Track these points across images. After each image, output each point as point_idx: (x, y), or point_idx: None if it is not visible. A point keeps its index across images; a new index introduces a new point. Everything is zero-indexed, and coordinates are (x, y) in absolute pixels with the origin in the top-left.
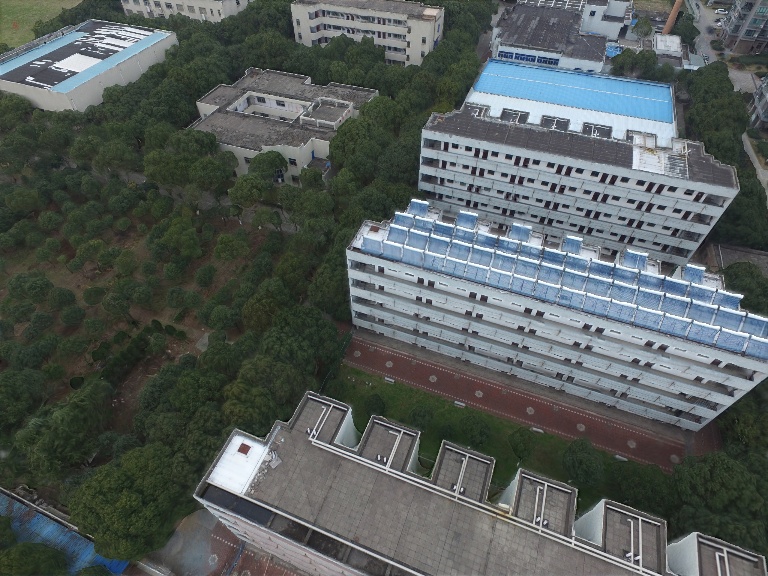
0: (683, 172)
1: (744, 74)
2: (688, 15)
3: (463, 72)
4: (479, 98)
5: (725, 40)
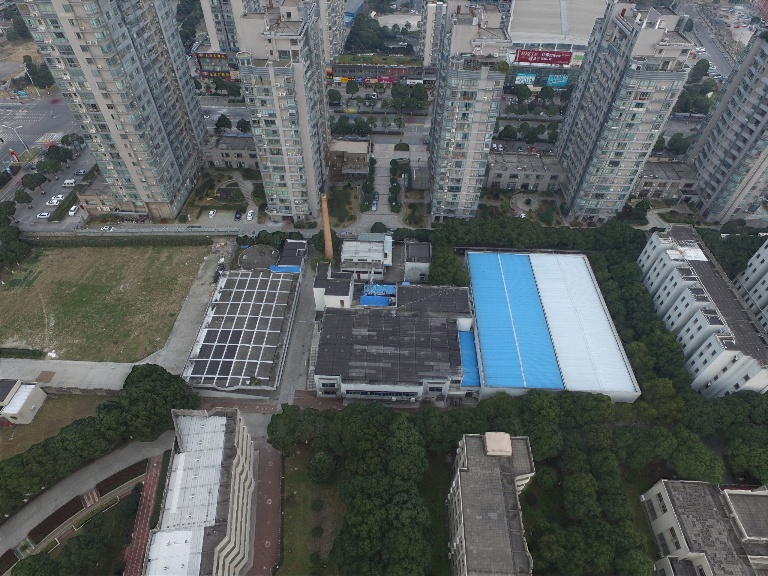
0: (690, 242)
1: (364, 217)
2: (264, 233)
3: (565, 397)
4: (580, 382)
5: (304, 218)
